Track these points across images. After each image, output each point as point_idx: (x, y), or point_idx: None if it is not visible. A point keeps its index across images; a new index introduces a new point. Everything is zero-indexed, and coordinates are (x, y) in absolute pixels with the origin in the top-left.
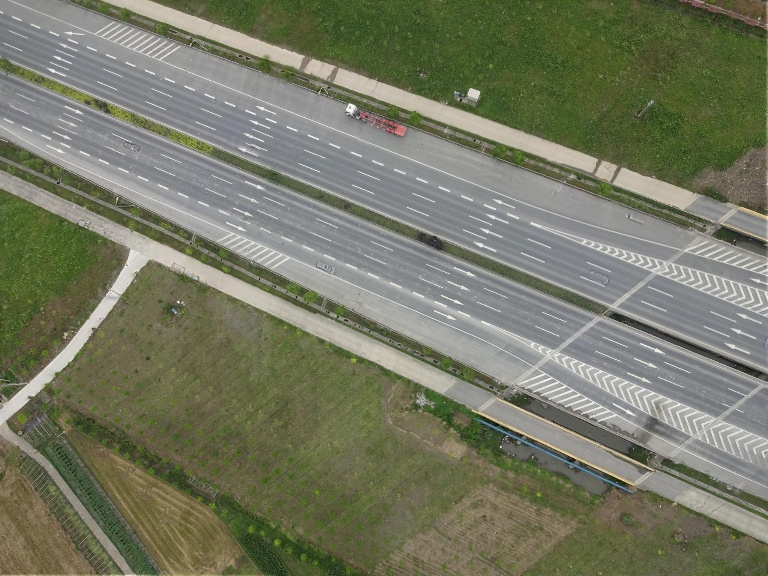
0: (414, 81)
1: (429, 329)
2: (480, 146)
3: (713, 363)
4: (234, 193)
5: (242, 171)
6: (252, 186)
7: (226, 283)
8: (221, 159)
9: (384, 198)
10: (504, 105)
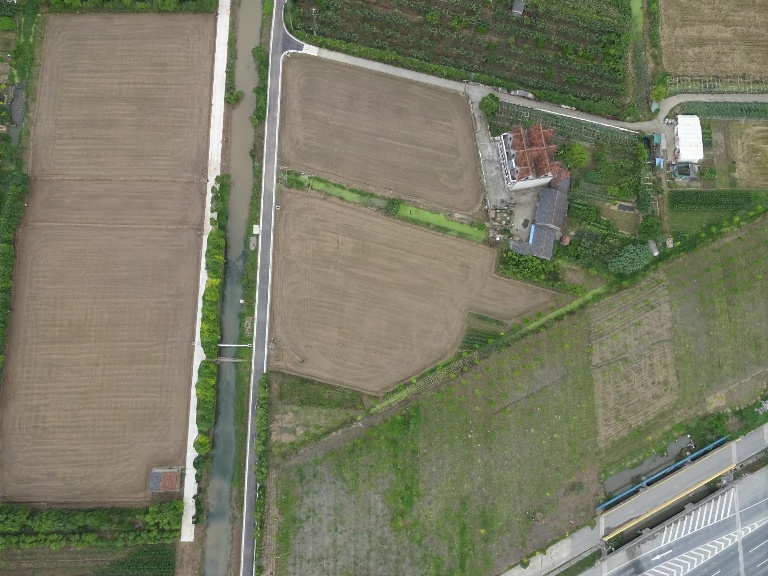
0: None
1: None
2: None
3: None
4: None
5: None
6: None
7: None
8: None
9: None
10: None
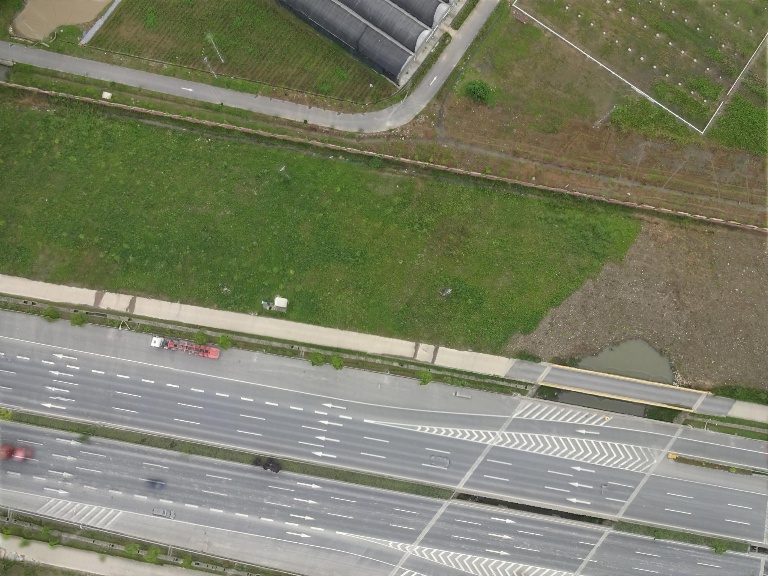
0: (218, 298)
1: (285, 553)
2: (299, 352)
3: (560, 521)
4: (46, 454)
5: (51, 429)
6: (65, 442)
7: (56, 555)
8: (24, 422)
9: (211, 426)
10: (314, 307)
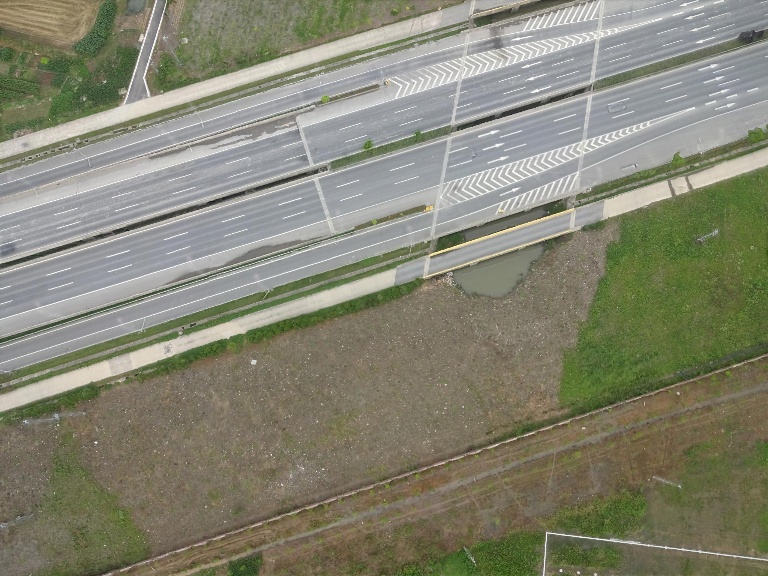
0: None
1: None
2: None
3: None
4: None
5: None
6: None
7: None
8: None
9: None
10: None
